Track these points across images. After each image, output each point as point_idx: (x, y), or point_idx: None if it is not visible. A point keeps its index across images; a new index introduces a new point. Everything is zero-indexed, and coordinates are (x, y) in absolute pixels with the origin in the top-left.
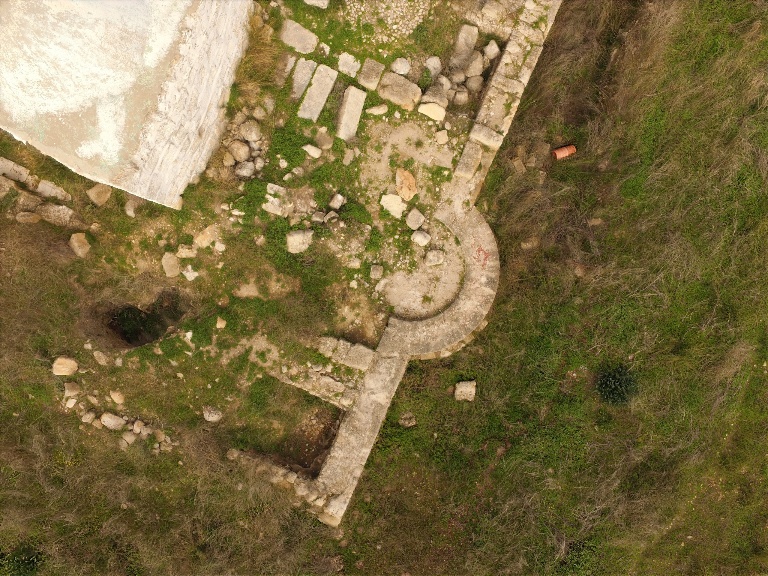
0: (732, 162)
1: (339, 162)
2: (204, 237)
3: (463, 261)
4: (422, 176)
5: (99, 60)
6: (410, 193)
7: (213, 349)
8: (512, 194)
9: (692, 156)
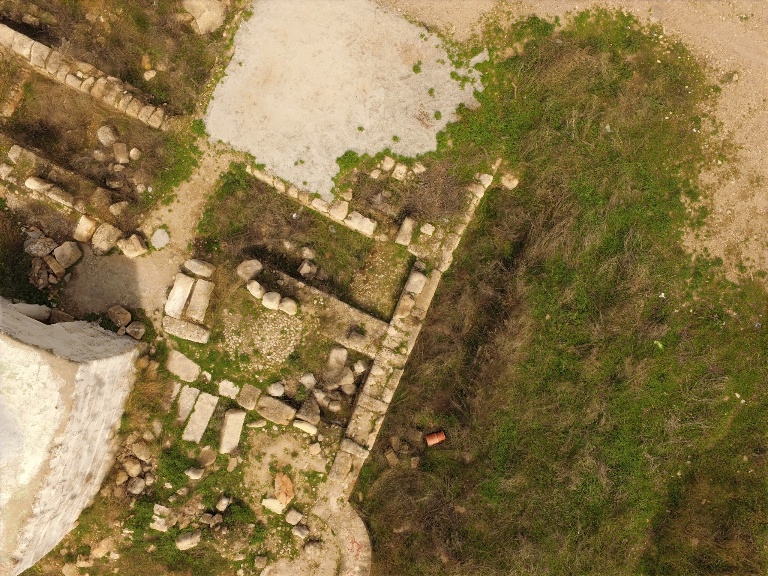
0: (571, 480)
1: (223, 471)
2: (99, 550)
3: (339, 550)
4: (299, 479)
5: None
6: (287, 499)
7: None
8: (382, 492)
9: (541, 462)
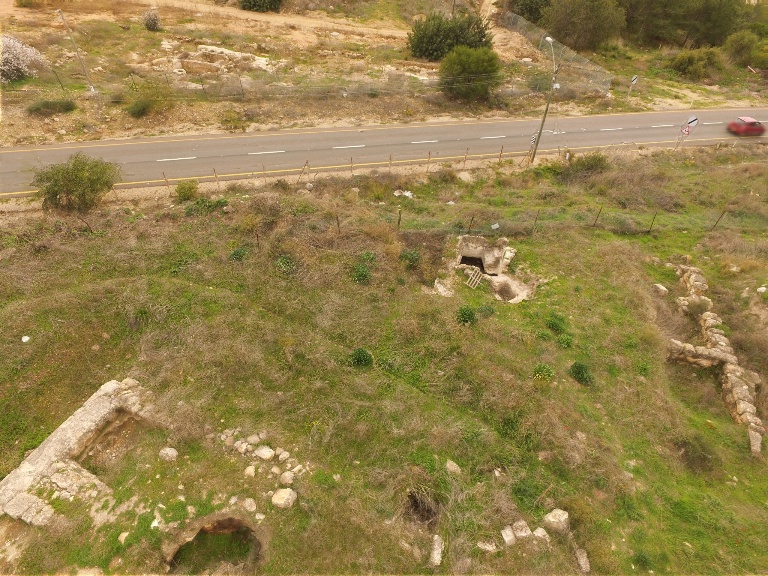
0: None
1: None
2: None
3: None
4: None
5: None
6: None
7: (140, 510)
8: None
9: None
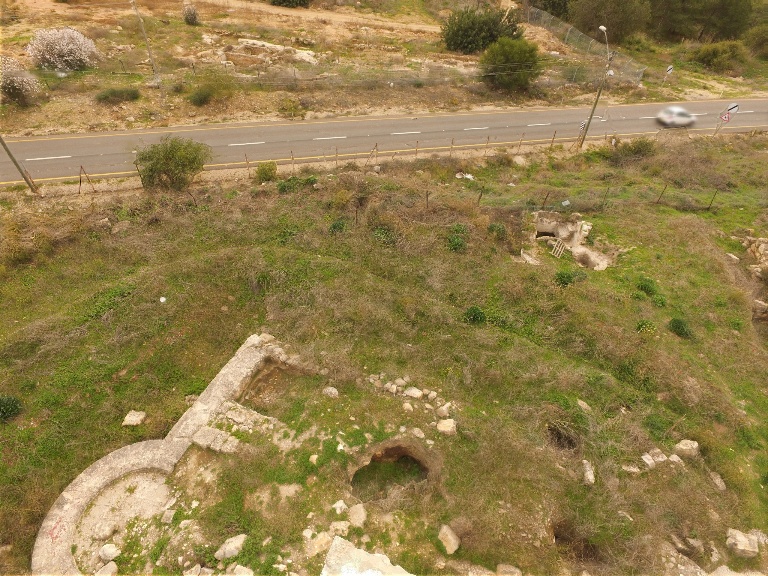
0: None
1: None
2: (320, 542)
3: (79, 528)
4: None
5: None
6: None
7: (322, 437)
8: None
9: None
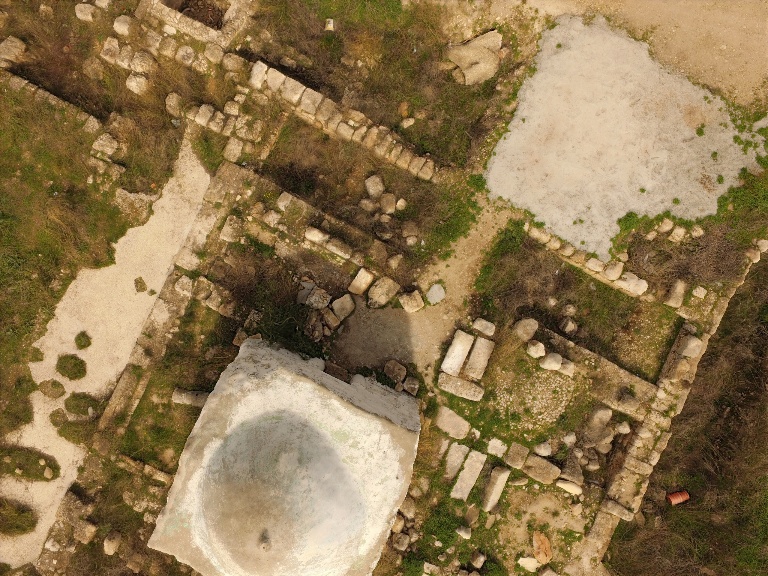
0: None
1: (483, 528)
2: None
3: None
4: (556, 538)
5: (326, 568)
6: (547, 559)
7: None
8: (636, 553)
9: None
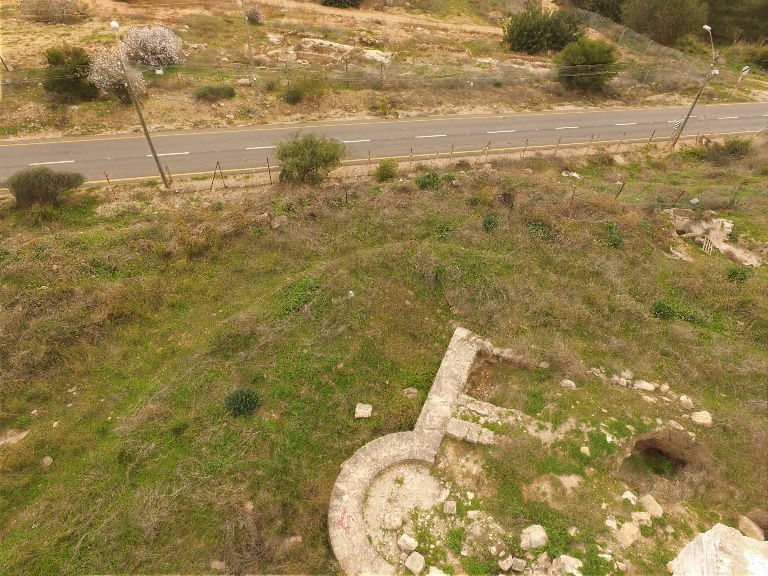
0: None
1: None
2: (631, 532)
3: (364, 518)
4: None
5: None
6: None
7: (585, 429)
8: None
9: None
